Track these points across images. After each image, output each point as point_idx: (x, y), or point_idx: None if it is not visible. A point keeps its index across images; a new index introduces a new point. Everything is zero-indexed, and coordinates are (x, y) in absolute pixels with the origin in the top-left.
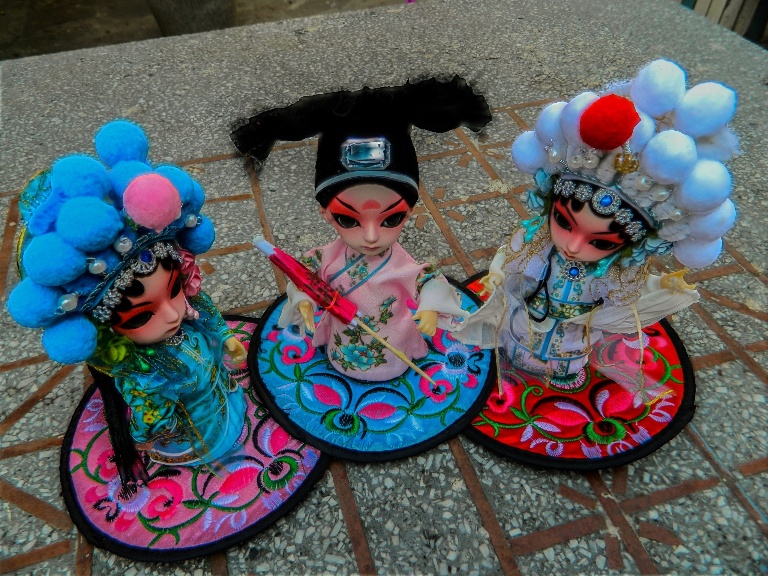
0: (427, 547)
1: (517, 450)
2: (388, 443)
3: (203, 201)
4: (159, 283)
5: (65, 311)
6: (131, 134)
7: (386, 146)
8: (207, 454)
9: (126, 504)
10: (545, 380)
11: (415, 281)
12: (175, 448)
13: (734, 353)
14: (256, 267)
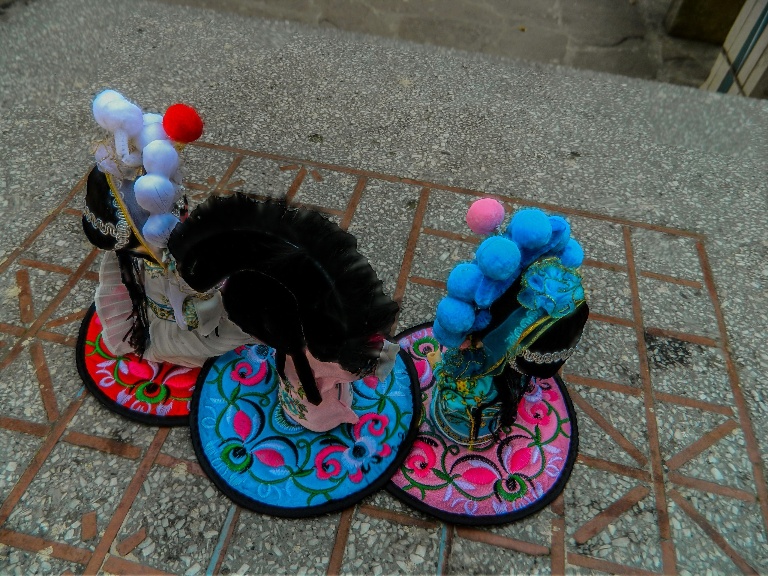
0: None
1: None
2: None
3: None
4: None
5: None
6: None
7: None
8: None
9: None
10: None
11: None
12: None
13: (83, 274)
14: None
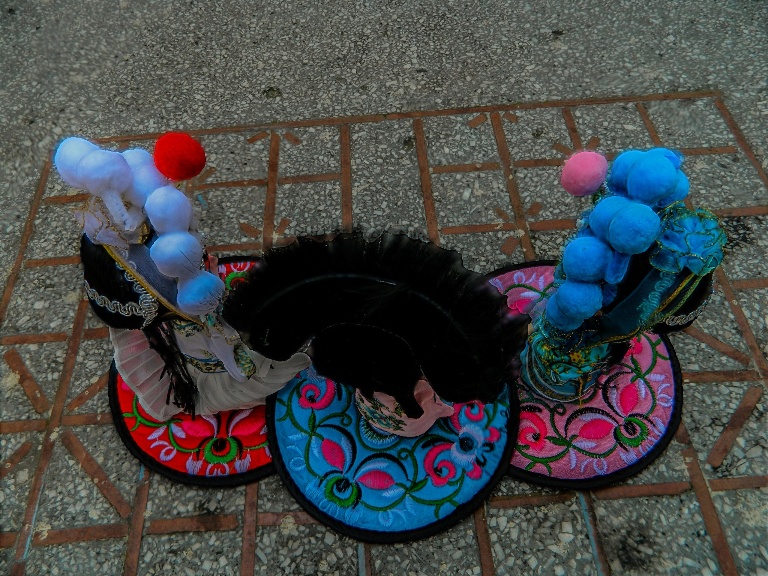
0: None
1: None
2: None
3: None
4: None
5: None
6: None
7: None
8: None
9: None
10: None
11: None
12: None
13: (82, 335)
14: None
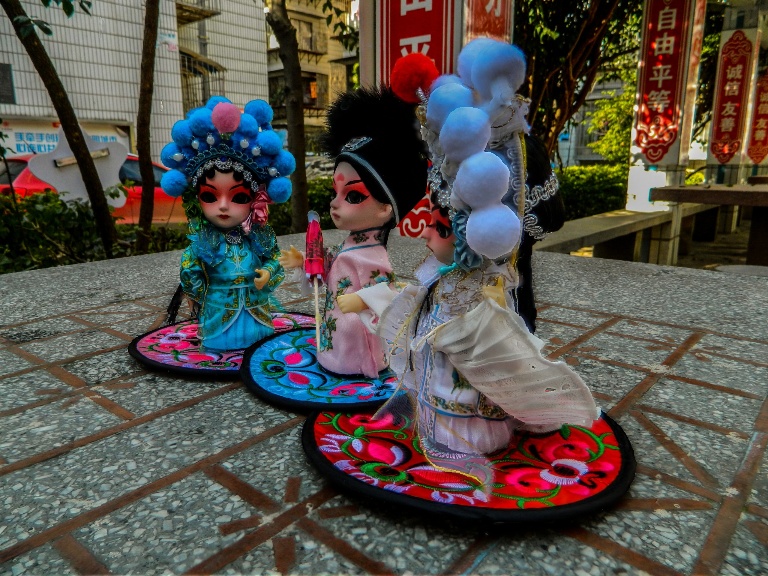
0: (189, 431)
1: (311, 433)
2: (270, 386)
3: (286, 165)
4: (225, 181)
5: (173, 158)
6: (258, 104)
7: (367, 140)
8: (209, 337)
9: None
10: (420, 437)
11: (370, 275)
12: (199, 318)
13: None
14: None
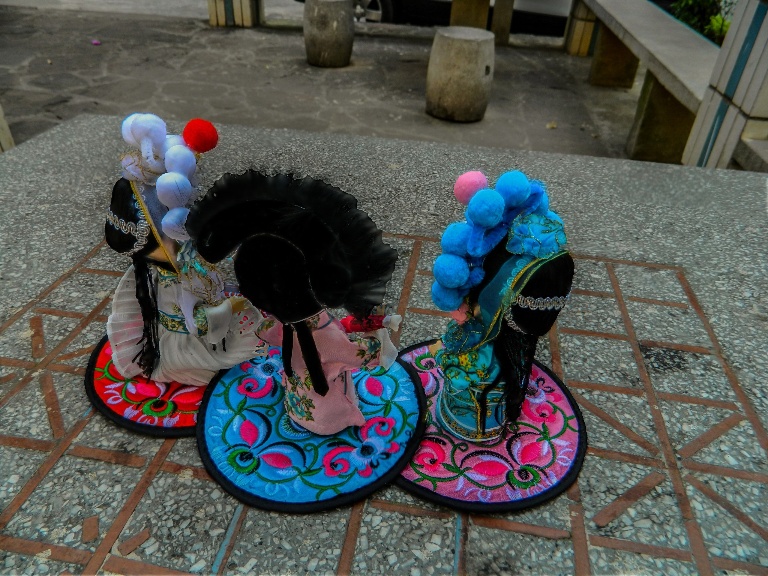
0: None
1: None
2: None
3: None
4: None
5: None
6: None
7: None
8: None
9: (532, 384)
10: None
11: None
12: None
13: (95, 317)
14: (372, 569)
